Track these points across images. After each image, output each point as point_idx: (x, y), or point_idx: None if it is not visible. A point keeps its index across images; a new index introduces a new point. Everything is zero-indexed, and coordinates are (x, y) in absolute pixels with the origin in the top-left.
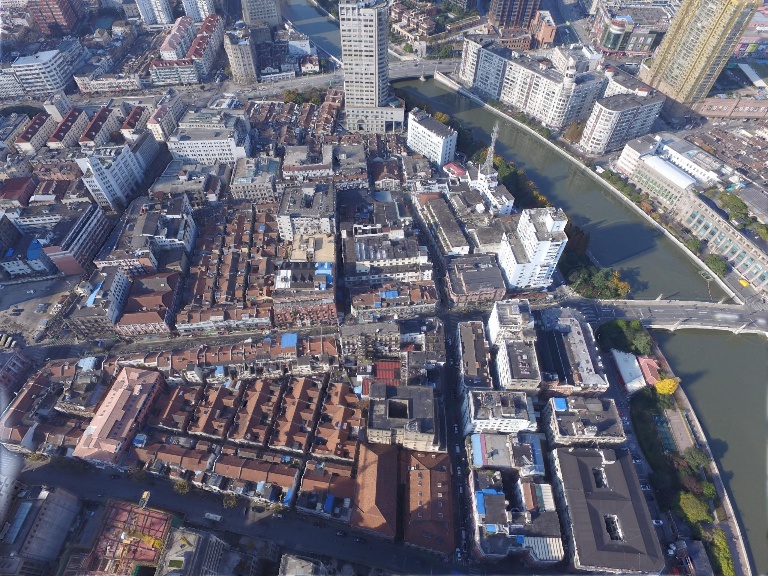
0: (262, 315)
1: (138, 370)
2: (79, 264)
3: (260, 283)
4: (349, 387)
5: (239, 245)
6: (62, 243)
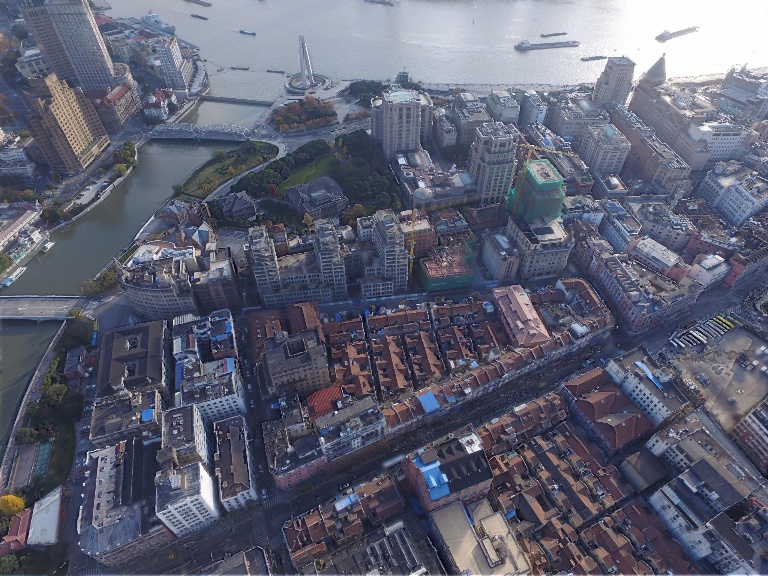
0: (480, 430)
1: (538, 340)
2: (737, 427)
3: (516, 474)
4: (356, 396)
5: (599, 536)
6: (766, 413)
